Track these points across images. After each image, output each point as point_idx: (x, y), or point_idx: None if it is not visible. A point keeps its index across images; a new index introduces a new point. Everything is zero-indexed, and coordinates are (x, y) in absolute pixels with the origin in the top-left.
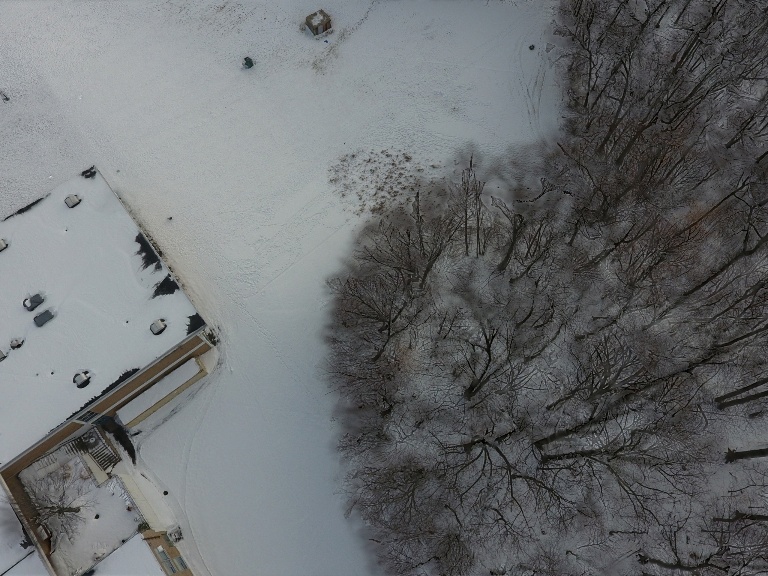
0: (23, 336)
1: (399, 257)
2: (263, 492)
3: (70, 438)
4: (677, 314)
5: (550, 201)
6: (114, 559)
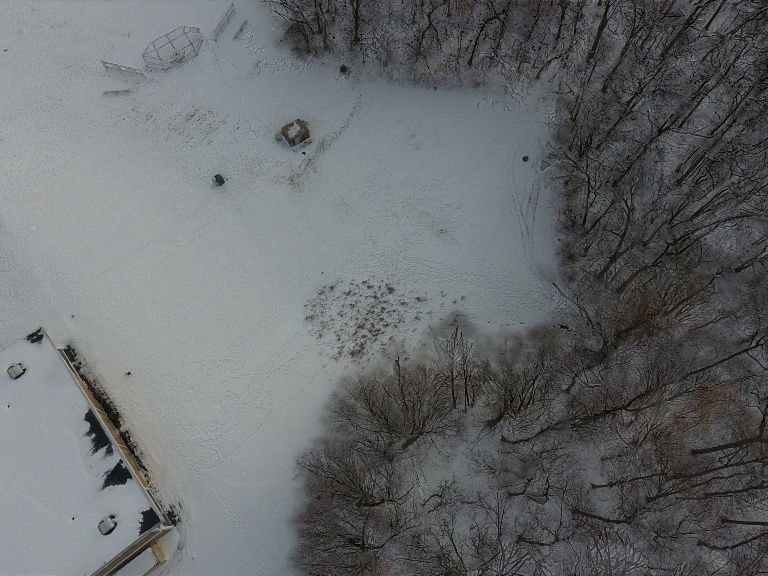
0: None
1: None
2: None
3: None
4: (685, 490)
5: (545, 338)
6: None
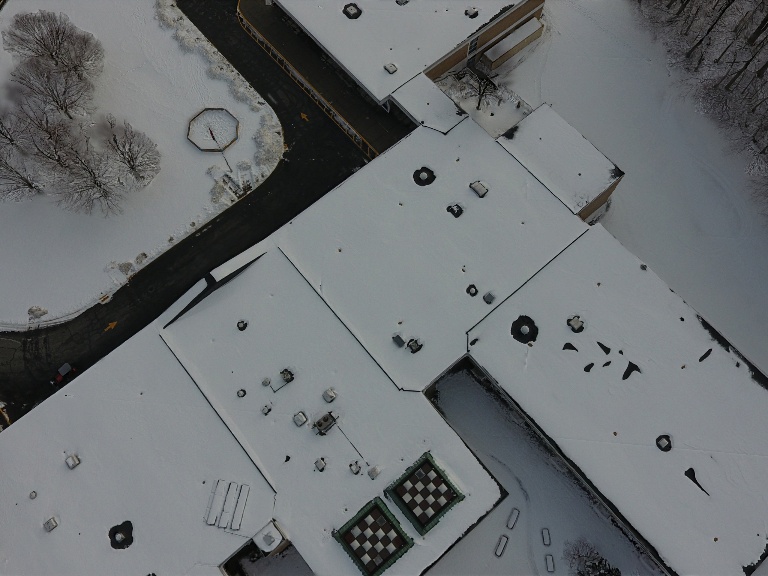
0: None
1: None
2: (605, 110)
3: (454, 70)
4: None
5: None
6: (531, 119)
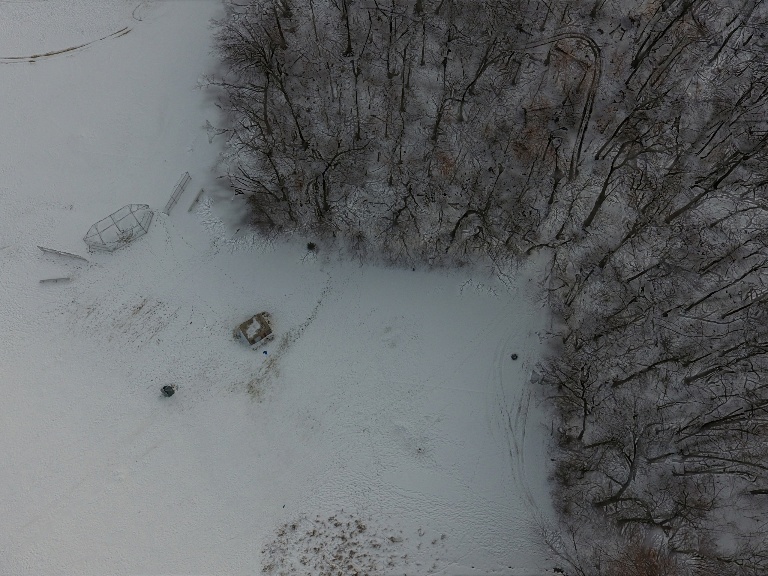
0: None
1: None
2: None
3: None
4: None
5: None
6: None
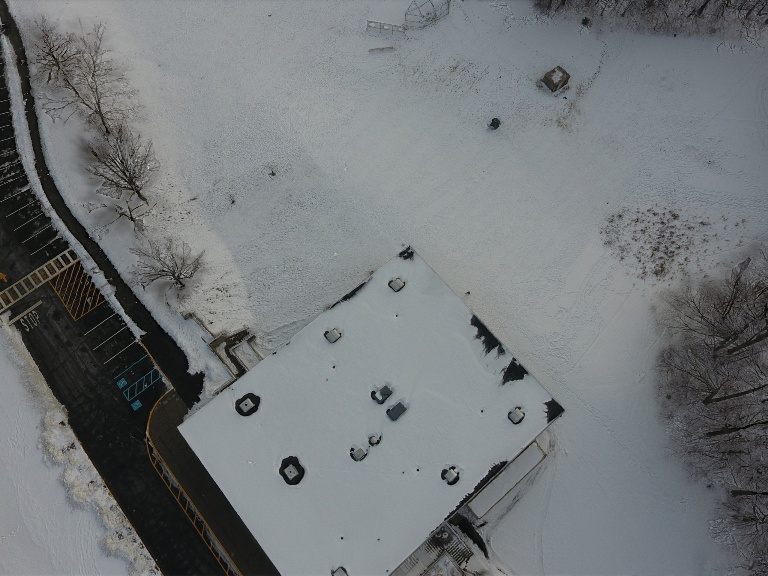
0: (380, 431)
1: (712, 324)
2: None
3: None
4: None
5: None
6: None
